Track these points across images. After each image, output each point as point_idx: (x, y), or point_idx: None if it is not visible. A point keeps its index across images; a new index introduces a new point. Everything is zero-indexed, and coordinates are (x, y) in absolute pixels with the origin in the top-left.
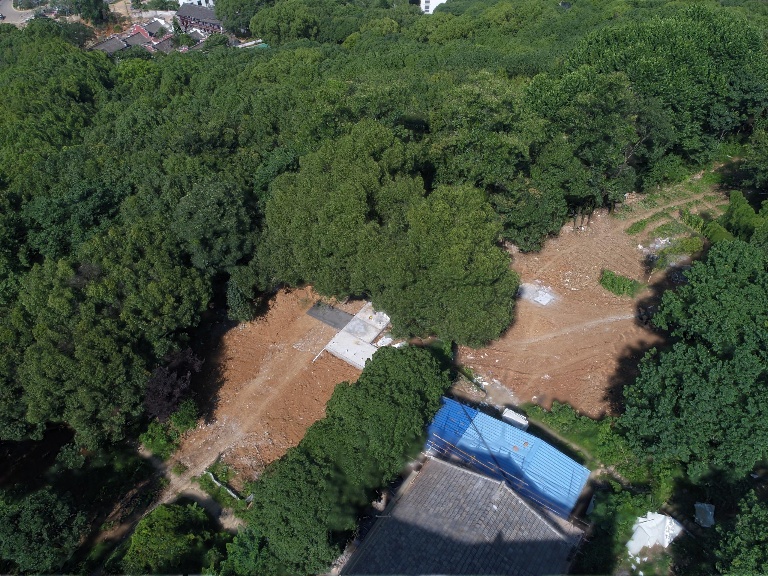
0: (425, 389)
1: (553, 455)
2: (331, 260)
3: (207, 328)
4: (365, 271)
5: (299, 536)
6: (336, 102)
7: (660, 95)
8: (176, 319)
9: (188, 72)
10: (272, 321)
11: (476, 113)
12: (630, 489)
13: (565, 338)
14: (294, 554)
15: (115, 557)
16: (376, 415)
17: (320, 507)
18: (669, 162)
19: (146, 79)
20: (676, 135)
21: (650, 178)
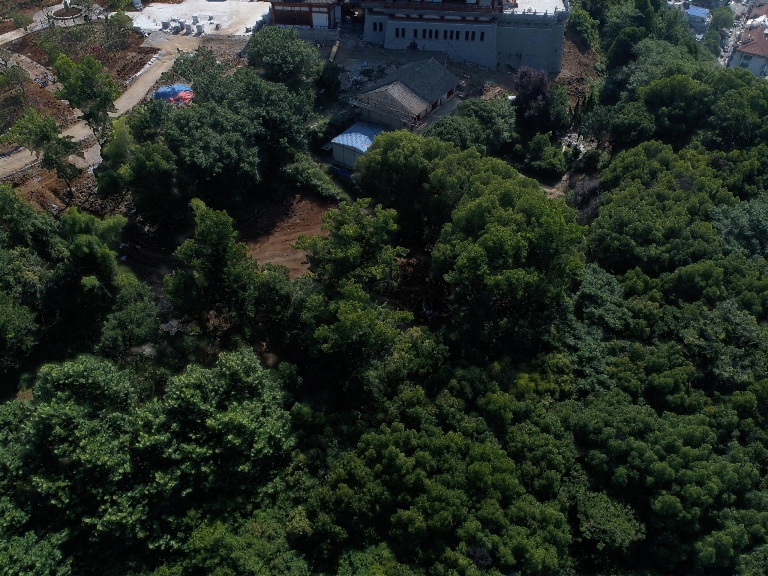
0: None
1: None
2: None
3: None
4: None
5: None
6: None
7: None
8: None
9: None
10: None
11: None
12: (308, 151)
13: None
14: None
15: (566, 151)
16: None
17: None
18: None
19: None
20: None
21: None
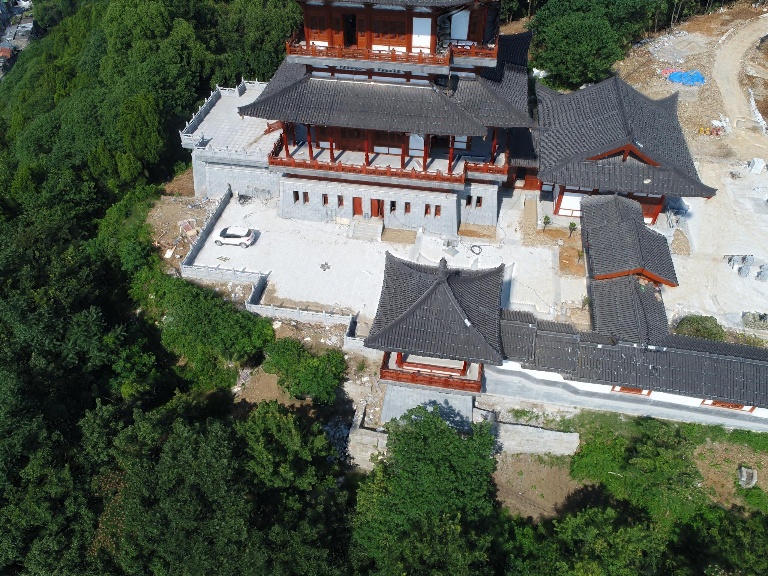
0: None
1: None
2: None
3: None
4: None
5: None
6: None
7: None
8: None
9: None
10: None
11: None
12: None
13: None
14: None
15: None
16: None
17: None
18: None
19: None
20: None
21: None
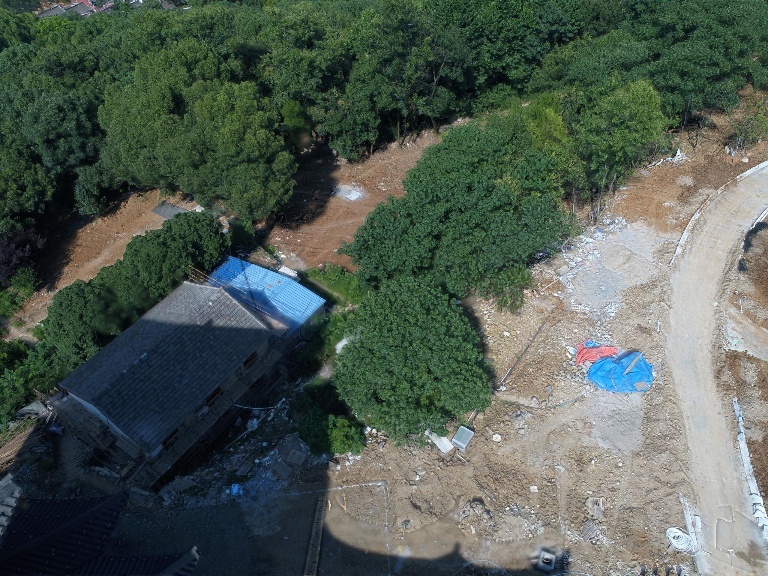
0: (202, 243)
1: (298, 289)
2: (145, 150)
3: (58, 219)
4: (166, 155)
5: (70, 335)
6: (163, 24)
7: (470, 25)
8: (20, 204)
9: (103, 28)
10: (120, 217)
11: (280, 31)
12: None
13: (361, 223)
14: (70, 353)
15: None
16: (146, 253)
17: (85, 312)
18: (499, 91)
19: (60, 34)
20: (492, 63)
21: (478, 104)
